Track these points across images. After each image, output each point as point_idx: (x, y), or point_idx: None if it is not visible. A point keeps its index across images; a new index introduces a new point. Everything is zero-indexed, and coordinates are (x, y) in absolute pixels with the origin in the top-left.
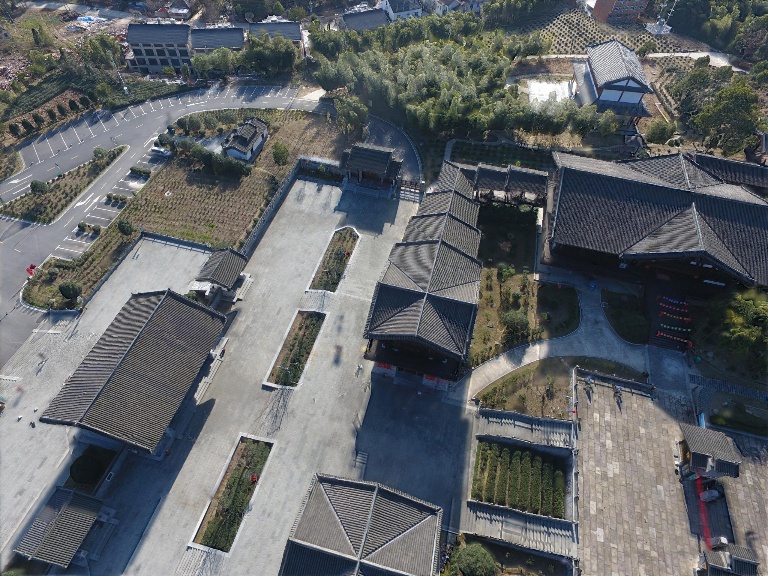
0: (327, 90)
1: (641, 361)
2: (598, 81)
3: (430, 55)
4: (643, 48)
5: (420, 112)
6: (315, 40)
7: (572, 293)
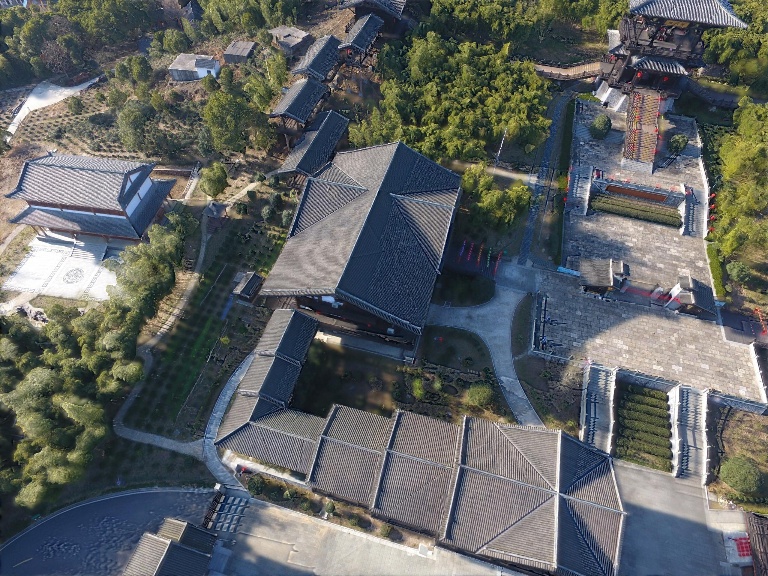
0: None
1: (511, 294)
2: (107, 207)
3: None
4: None
5: (64, 476)
6: None
7: (433, 330)
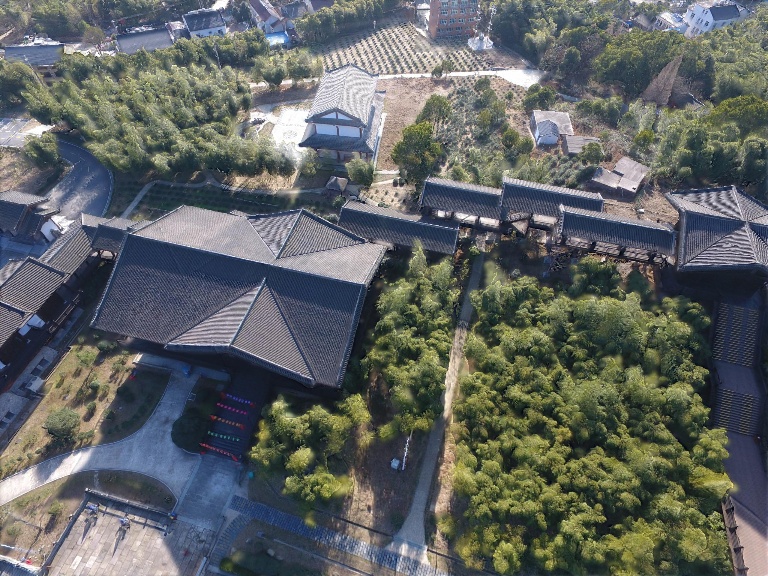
0: (44, 124)
1: (184, 477)
2: (310, 113)
3: (167, 82)
4: (437, 68)
5: (94, 153)
6: (57, 66)
7: (163, 381)
